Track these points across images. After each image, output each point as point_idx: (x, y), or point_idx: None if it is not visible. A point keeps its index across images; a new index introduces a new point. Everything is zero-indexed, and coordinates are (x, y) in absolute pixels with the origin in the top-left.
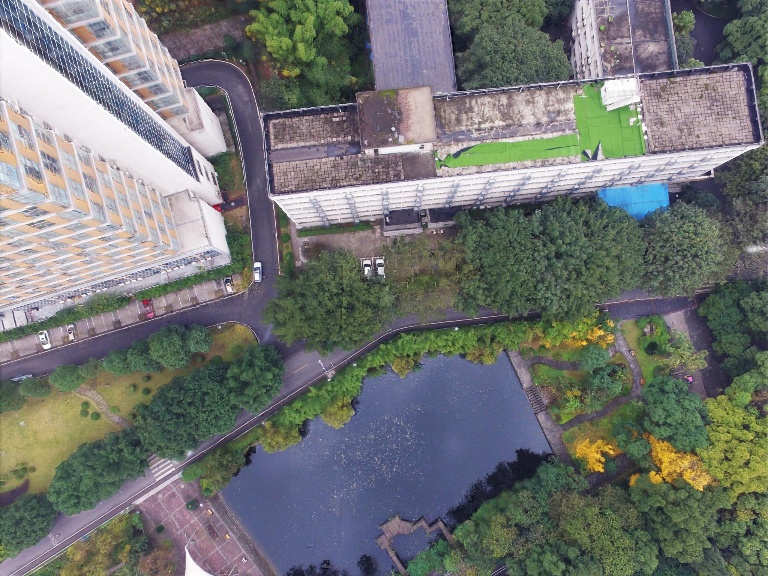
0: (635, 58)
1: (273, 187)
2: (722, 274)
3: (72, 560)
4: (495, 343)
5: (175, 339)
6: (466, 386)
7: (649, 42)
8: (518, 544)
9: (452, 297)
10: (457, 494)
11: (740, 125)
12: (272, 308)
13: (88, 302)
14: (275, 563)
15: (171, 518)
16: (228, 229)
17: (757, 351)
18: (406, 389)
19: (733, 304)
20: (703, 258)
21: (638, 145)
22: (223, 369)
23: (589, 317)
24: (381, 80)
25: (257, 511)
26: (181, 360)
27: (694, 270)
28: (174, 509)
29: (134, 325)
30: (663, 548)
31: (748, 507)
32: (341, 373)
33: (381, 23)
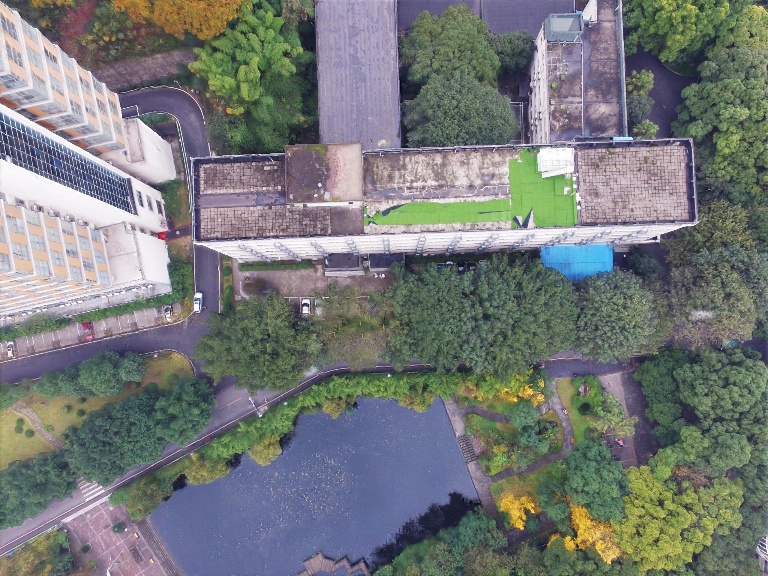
0: (585, 118)
1: (199, 232)
2: (654, 345)
3: None
4: (427, 392)
5: (106, 367)
6: (399, 430)
7: (600, 103)
8: None
9: (377, 351)
10: (382, 536)
11: (676, 202)
12: (202, 345)
13: (26, 322)
14: None
15: (98, 538)
16: (171, 257)
17: (684, 424)
18: (339, 428)
19: (668, 373)
20: (631, 332)
21: (570, 215)
22: (154, 399)
23: (521, 375)
24: (325, 124)
25: (183, 538)
26: (112, 388)
27: (622, 342)
28: (101, 530)
29: (73, 346)
30: None
31: None
32: (272, 410)
33: (330, 65)
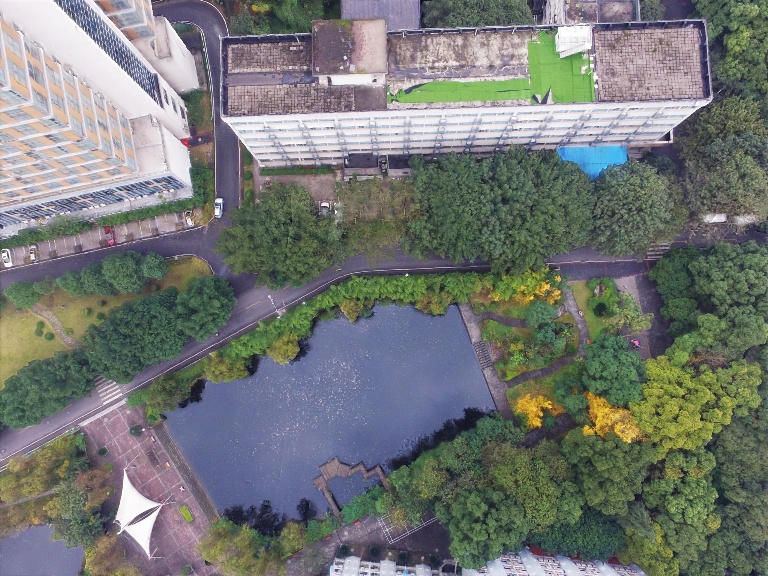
0: (599, 16)
1: (226, 109)
2: (669, 234)
3: (12, 471)
4: (444, 292)
5: (129, 262)
6: (415, 336)
7: (614, 2)
8: (448, 488)
9: (397, 235)
10: (398, 442)
11: (691, 81)
12: (224, 237)
13: (50, 222)
14: (213, 495)
15: (114, 442)
16: (193, 164)
17: (700, 314)
18: (356, 335)
19: (683, 269)
20: (647, 212)
21: (588, 93)
22: (175, 297)
23: (538, 272)
24: None
25: (199, 443)
26: (134, 284)
27: (639, 225)
28: (118, 433)
29: (94, 251)
30: (587, 497)
31: (675, 463)
32: (291, 311)
33: None
